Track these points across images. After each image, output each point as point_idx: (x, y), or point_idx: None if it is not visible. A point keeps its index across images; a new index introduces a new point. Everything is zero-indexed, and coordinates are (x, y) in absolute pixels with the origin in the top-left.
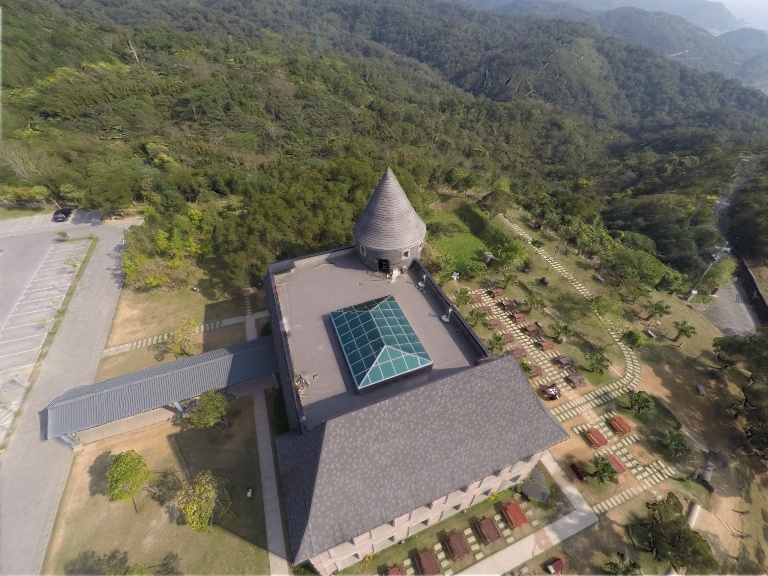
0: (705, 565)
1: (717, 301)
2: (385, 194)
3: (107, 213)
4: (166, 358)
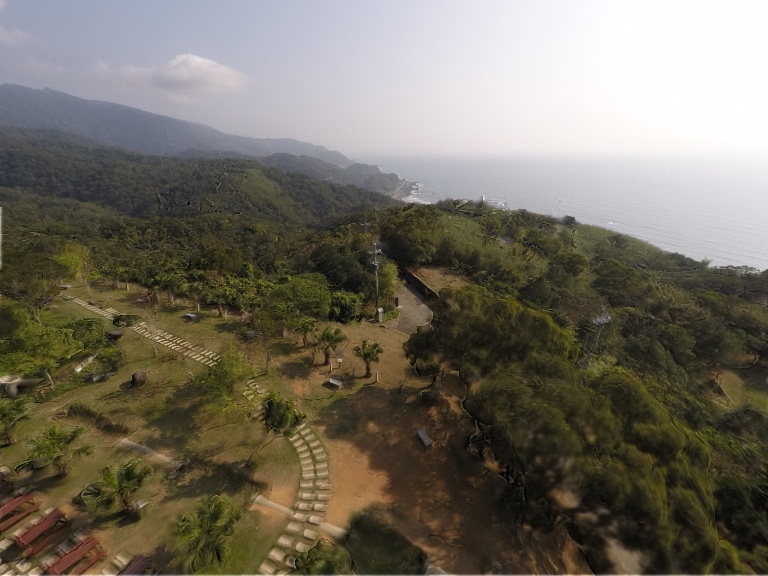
0: None
1: (403, 311)
2: None
3: None
4: None
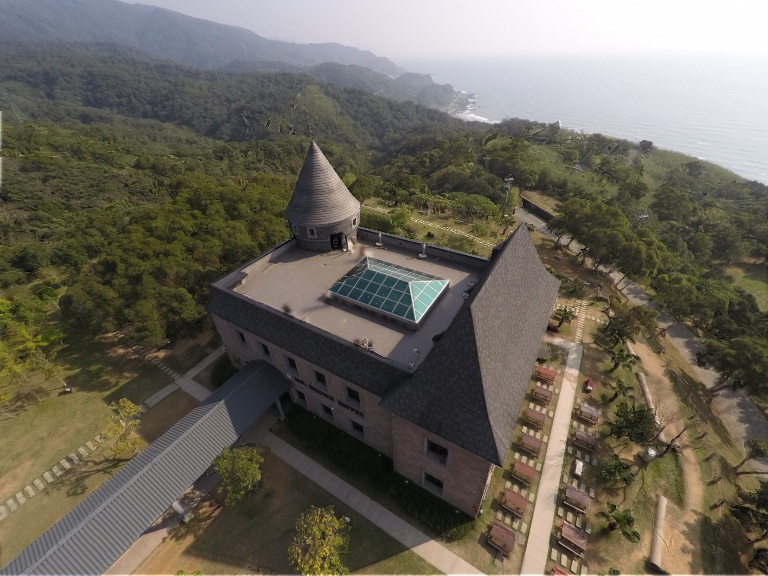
0: (653, 317)
1: (518, 217)
2: (318, 168)
3: None
4: (91, 484)
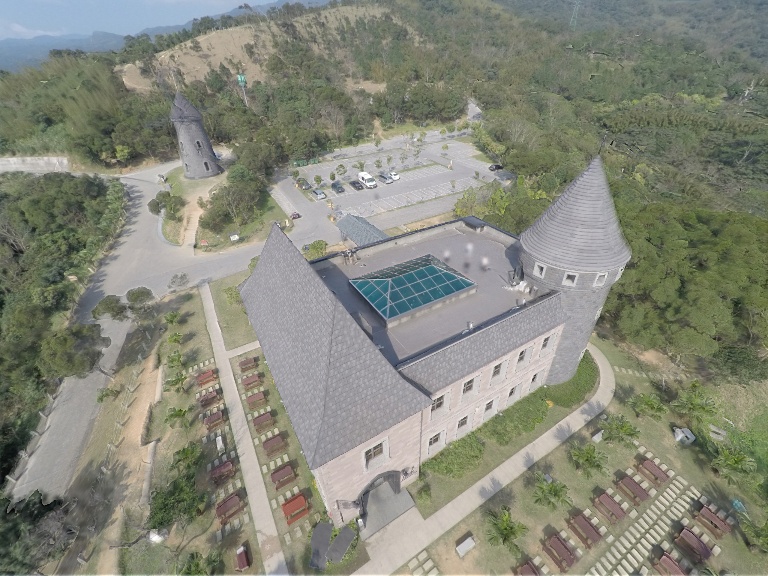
0: None
1: None
2: (572, 187)
3: (515, 177)
4: None
